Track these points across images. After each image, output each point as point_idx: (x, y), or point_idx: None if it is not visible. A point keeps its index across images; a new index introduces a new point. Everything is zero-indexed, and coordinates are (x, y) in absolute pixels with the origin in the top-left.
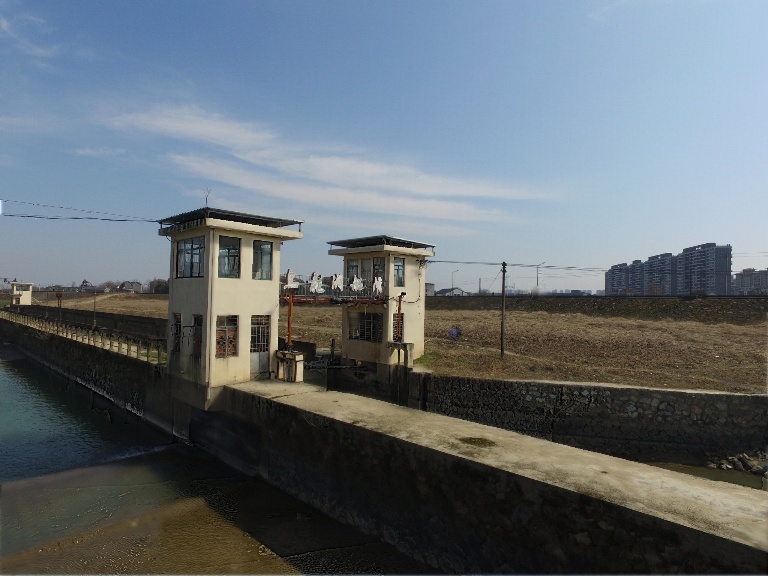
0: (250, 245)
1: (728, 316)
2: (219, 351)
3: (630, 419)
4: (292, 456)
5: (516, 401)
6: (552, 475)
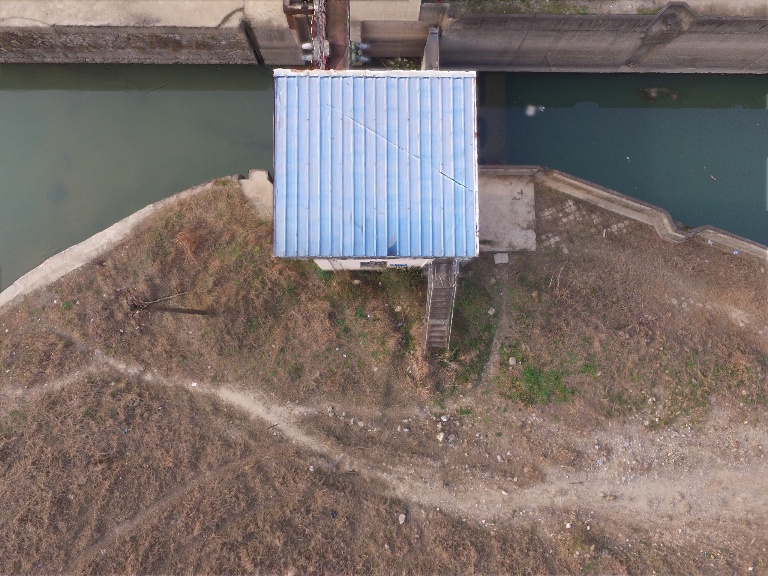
0: None
1: None
2: None
3: None
4: None
5: None
6: None
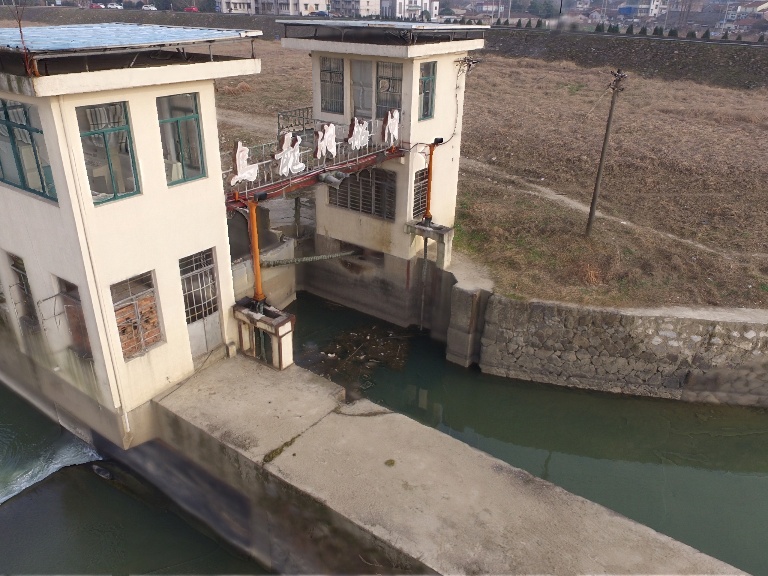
0: (151, 112)
1: None
2: (128, 345)
3: None
4: (325, 574)
5: (636, 345)
6: None
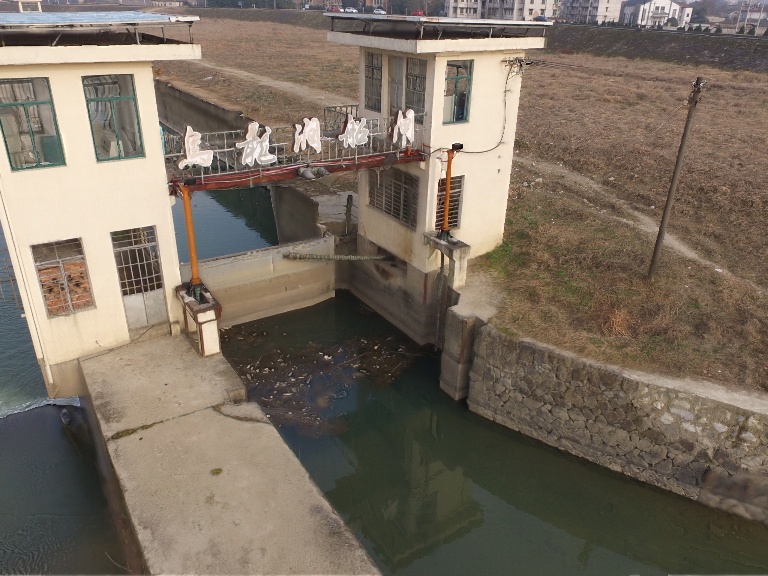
0: (75, 90)
1: None
2: (55, 303)
3: None
4: None
5: (639, 418)
6: None
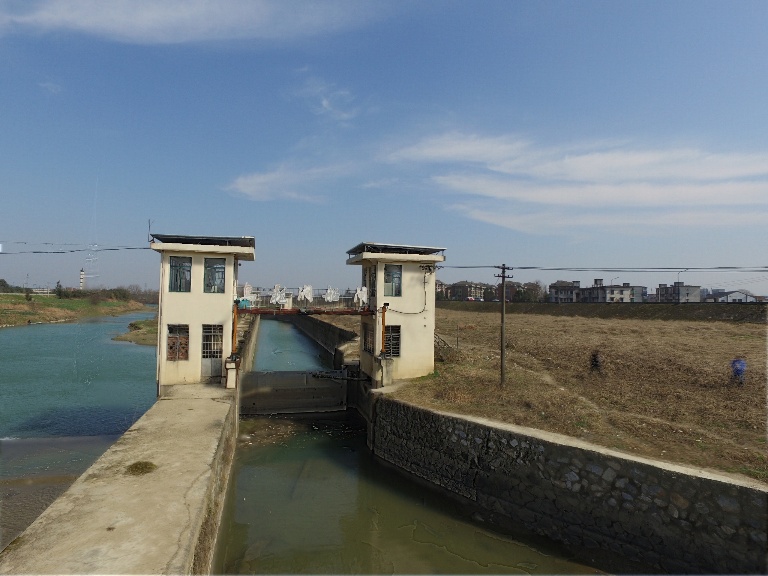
0: (201, 262)
1: None
2: (171, 355)
3: (569, 492)
4: None
5: (441, 439)
6: (64, 515)
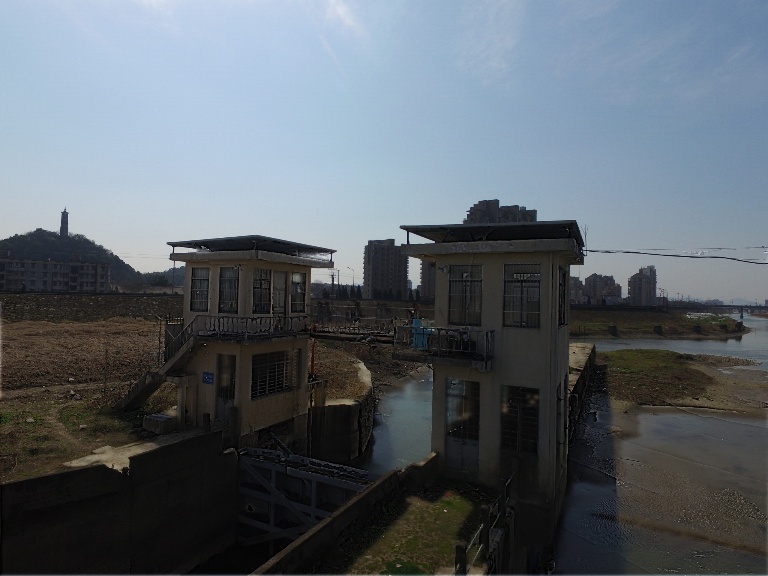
0: None
1: (55, 313)
2: None
3: None
4: None
5: None
6: None
